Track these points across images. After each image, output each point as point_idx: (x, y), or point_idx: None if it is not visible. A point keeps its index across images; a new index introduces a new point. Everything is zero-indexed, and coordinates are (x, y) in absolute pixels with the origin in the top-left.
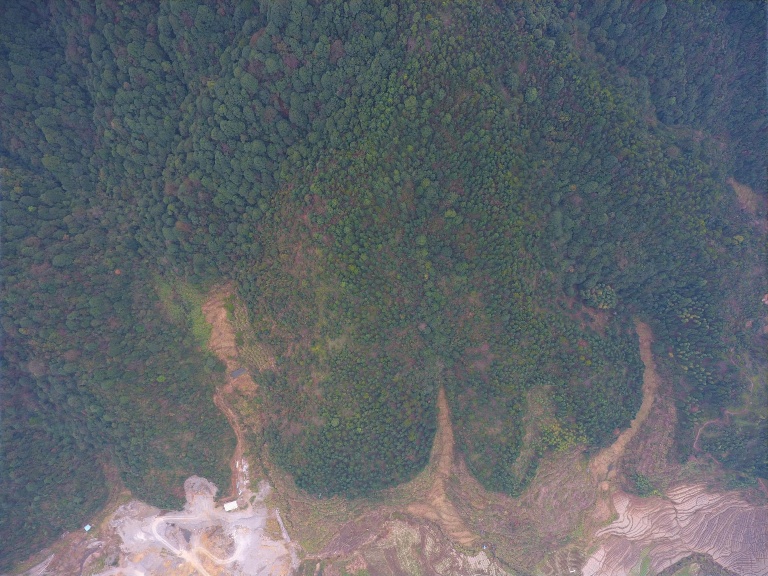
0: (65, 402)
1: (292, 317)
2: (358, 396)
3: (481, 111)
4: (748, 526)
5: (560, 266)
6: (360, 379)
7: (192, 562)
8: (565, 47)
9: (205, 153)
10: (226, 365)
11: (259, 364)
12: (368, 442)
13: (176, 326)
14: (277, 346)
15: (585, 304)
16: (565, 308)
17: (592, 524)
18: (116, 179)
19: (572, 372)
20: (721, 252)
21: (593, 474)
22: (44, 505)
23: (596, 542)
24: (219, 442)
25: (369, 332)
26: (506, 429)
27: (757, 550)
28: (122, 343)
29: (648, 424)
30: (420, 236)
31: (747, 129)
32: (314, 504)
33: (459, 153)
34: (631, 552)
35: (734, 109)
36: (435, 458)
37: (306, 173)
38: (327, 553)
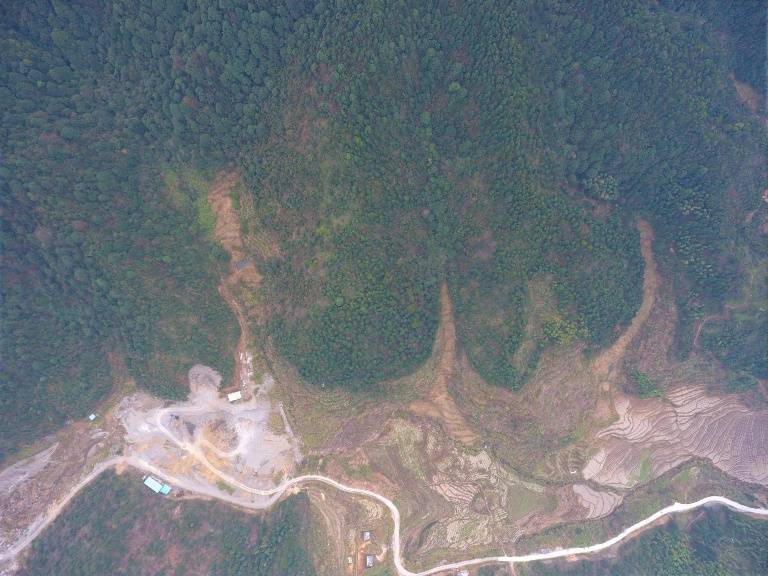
0: (72, 278)
1: (297, 197)
2: (362, 276)
3: None
4: (748, 431)
5: (563, 149)
6: (364, 258)
7: (196, 454)
8: None
9: (213, 23)
10: (231, 256)
11: (264, 252)
12: (372, 324)
13: (182, 214)
14: (282, 231)
15: (587, 194)
16: (567, 193)
17: (593, 424)
18: (124, 58)
19: (574, 259)
20: (722, 138)
21: (594, 374)
22: (50, 388)
23: (597, 444)
24: (224, 329)
25: (373, 211)
26: (508, 318)
27: (756, 455)
28: (129, 220)
29: (649, 324)
30: (424, 112)
31: (748, 23)
32: (317, 397)
33: (464, 18)
34: (631, 455)
35: (735, 3)
36: (437, 352)
37: (312, 41)
38: (330, 449)
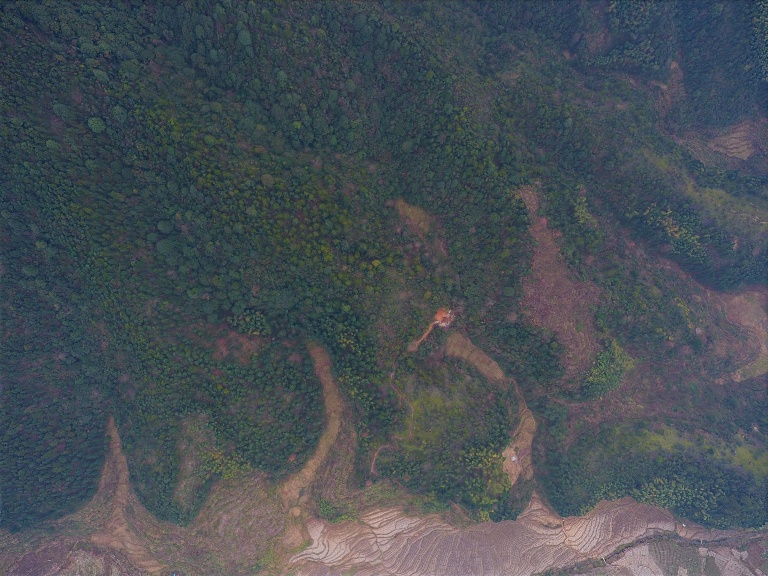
0: None
1: None
2: None
3: (15, 144)
4: (453, 549)
5: (187, 294)
6: None
7: None
8: (124, 76)
9: None
10: None
11: None
12: None
13: None
14: None
15: (236, 330)
16: (200, 336)
17: (283, 551)
18: None
19: None
20: (358, 277)
21: (283, 500)
22: None
23: (292, 568)
24: None
25: None
26: (158, 459)
27: (462, 573)
28: None
29: (335, 449)
30: (23, 267)
31: (401, 151)
32: None
33: (20, 185)
34: None
35: (387, 131)
36: (105, 488)
37: None
38: None
